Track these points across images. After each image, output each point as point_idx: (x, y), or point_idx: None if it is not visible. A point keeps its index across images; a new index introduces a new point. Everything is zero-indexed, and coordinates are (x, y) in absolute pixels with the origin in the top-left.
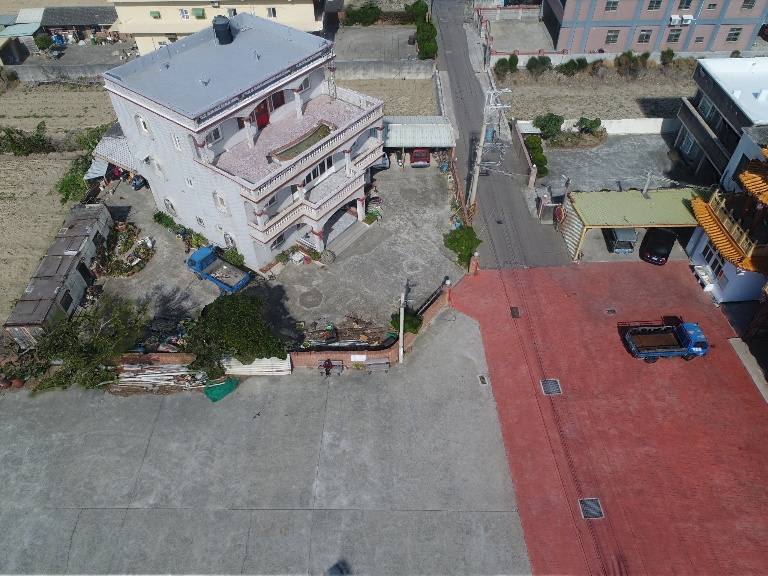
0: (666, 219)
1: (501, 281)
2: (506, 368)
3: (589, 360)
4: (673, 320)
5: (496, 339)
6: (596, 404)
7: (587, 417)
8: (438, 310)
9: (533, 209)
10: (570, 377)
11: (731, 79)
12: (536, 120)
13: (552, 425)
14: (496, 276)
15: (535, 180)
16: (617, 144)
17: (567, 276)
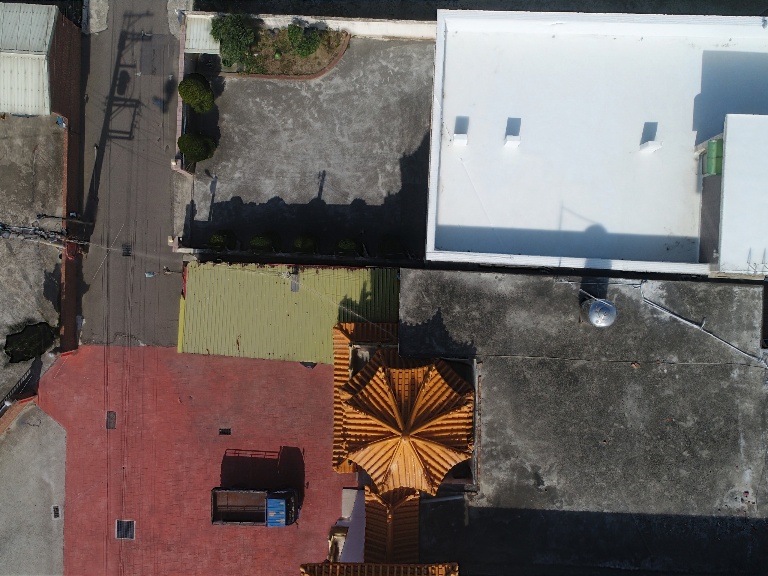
0: (294, 348)
1: (105, 367)
2: (83, 500)
3: (175, 500)
4: (292, 454)
5: (81, 459)
6: (165, 557)
7: (151, 571)
8: (18, 412)
9: (178, 228)
10: (148, 520)
11: (496, 61)
12: (213, 22)
13: (114, 575)
14: (101, 358)
15: (188, 172)
16: (359, 68)
17: (189, 366)
